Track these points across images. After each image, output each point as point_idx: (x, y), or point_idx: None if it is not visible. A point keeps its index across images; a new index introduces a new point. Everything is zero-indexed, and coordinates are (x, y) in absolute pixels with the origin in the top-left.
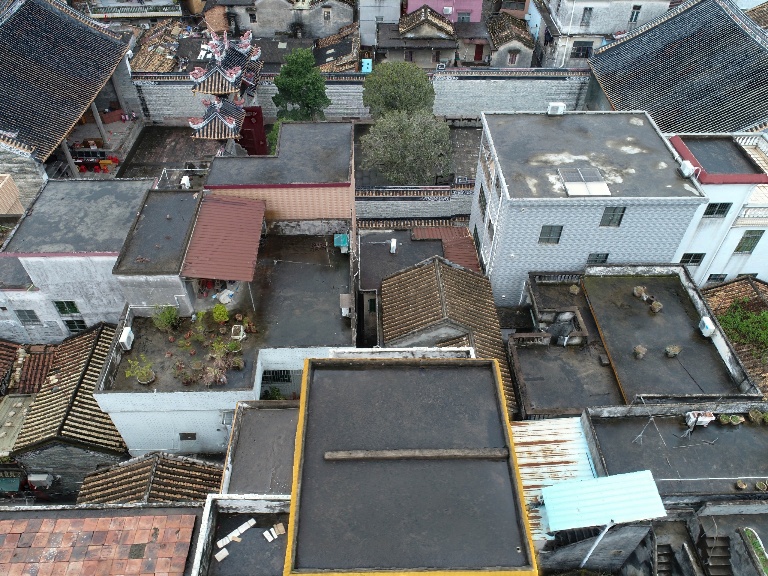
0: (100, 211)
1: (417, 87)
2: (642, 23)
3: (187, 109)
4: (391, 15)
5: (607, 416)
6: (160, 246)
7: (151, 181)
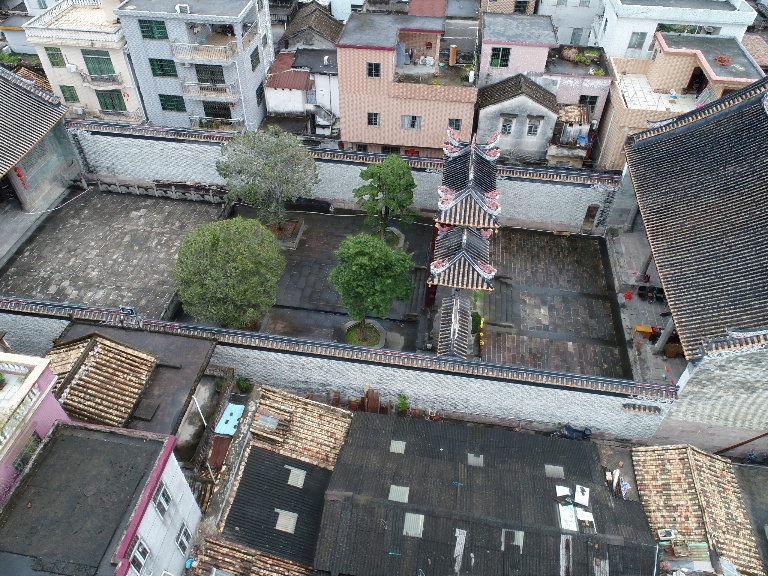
0: (510, 29)
1: None
2: None
3: None
4: None
5: None
6: None
7: None
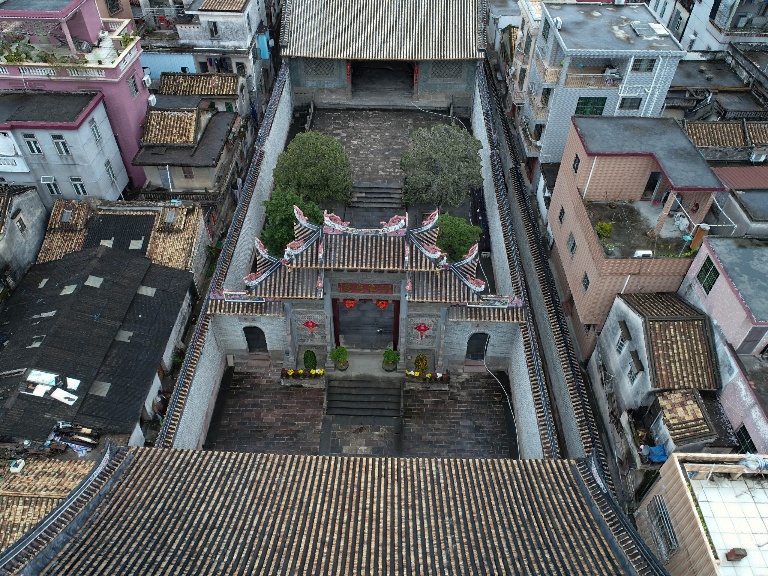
0: None
1: None
2: (260, 8)
3: (193, 438)
4: (112, 150)
5: None
6: None
7: (709, 241)
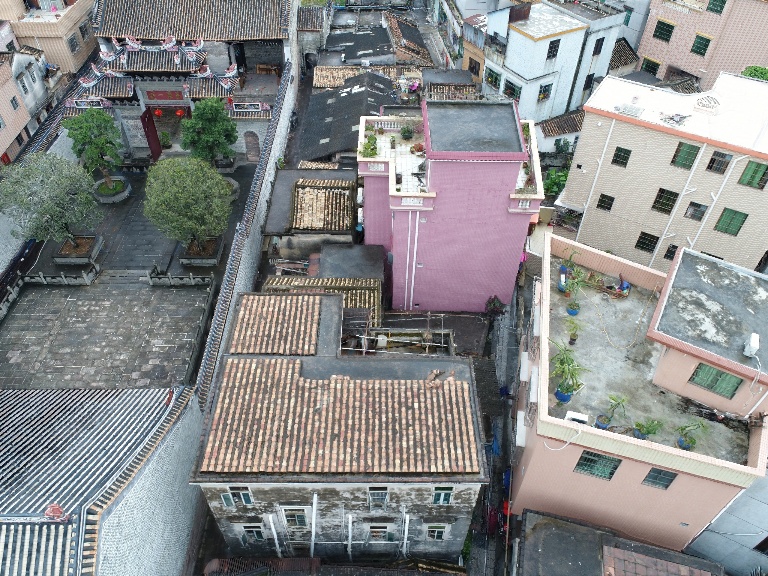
0: None
1: None
2: None
3: None
4: None
5: None
6: None
7: None
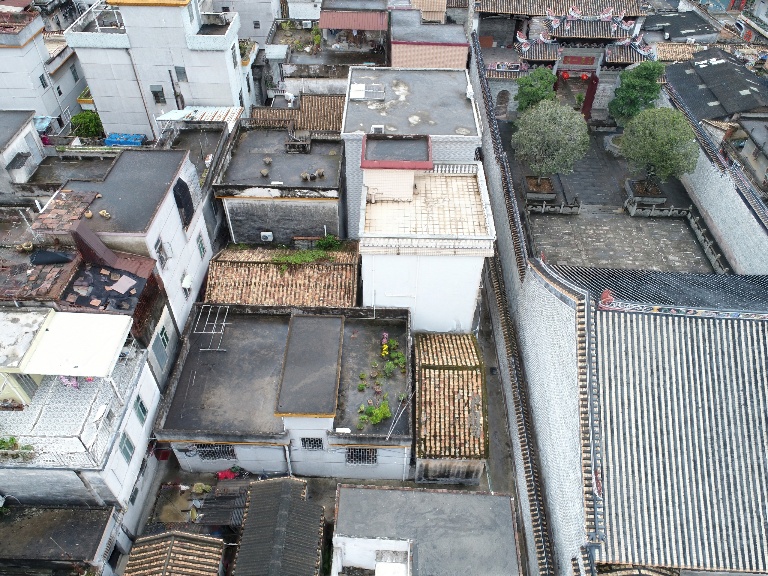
0: None
1: (653, 136)
2: None
3: None
4: None
5: None
6: (341, 4)
7: None
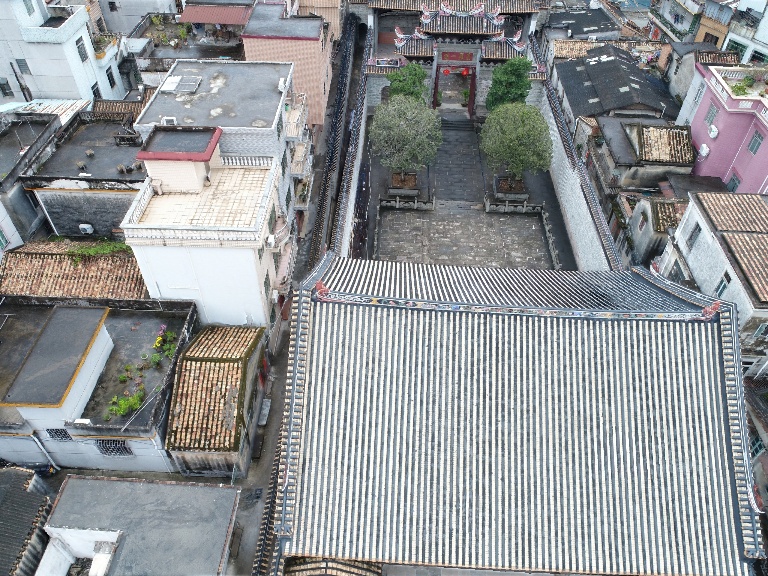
0: None
1: None
2: None
3: None
4: None
5: (55, 129)
6: None
7: None
